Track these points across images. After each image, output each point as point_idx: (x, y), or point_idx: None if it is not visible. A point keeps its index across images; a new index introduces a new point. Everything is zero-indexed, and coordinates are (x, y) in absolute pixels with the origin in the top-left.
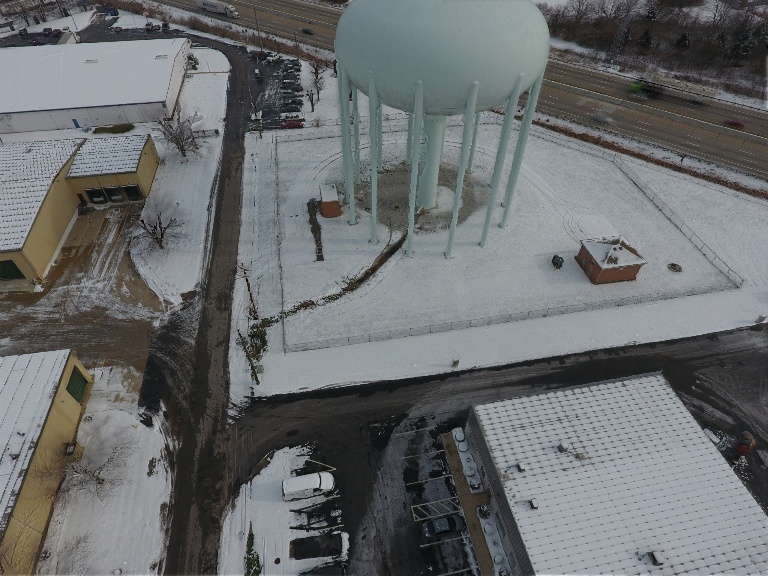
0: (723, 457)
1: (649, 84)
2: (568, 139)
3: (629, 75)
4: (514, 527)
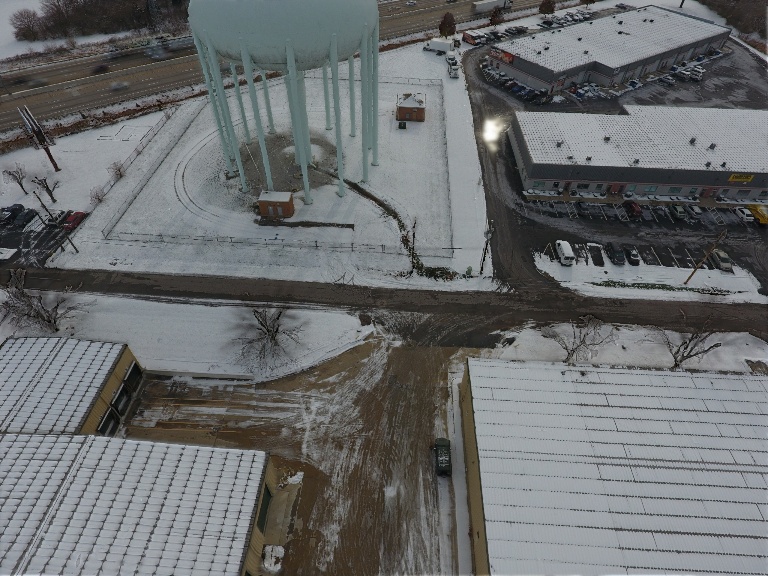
0: None
1: None
2: (261, 83)
3: None
4: (598, 168)
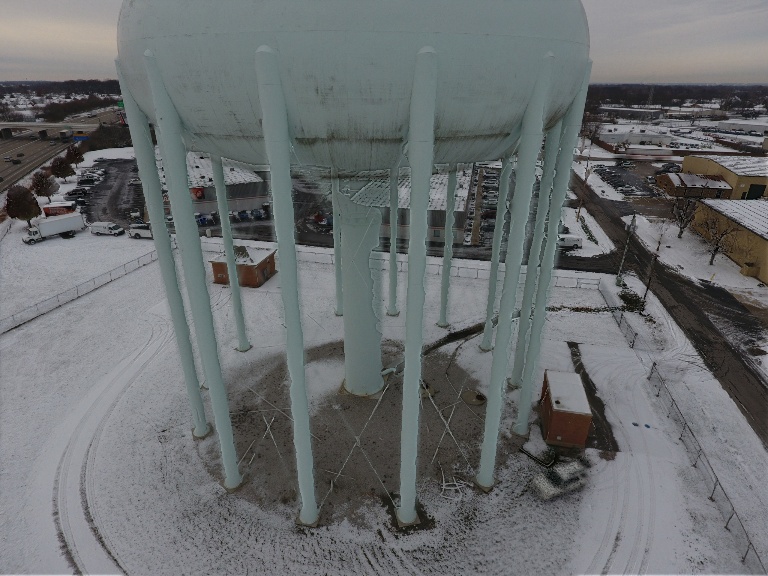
0: None
1: None
2: None
3: None
4: None
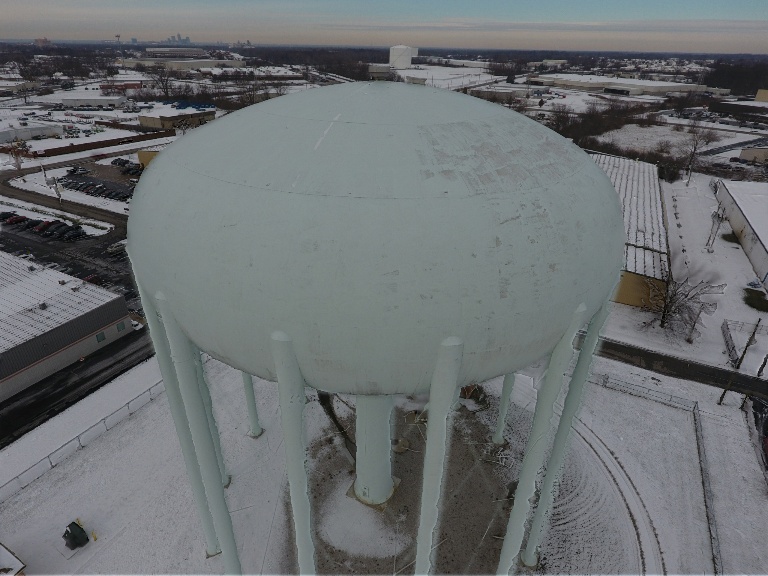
0: None
1: None
2: None
3: None
4: None
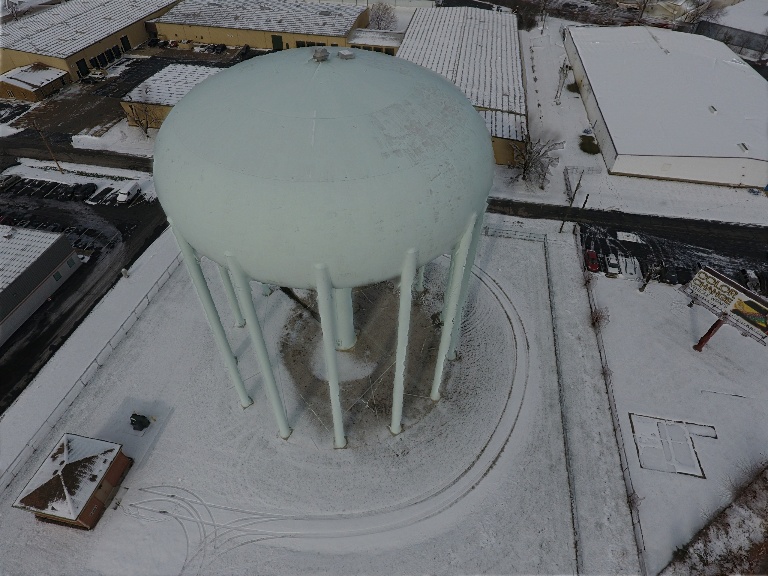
0: None
1: None
2: None
3: None
4: None
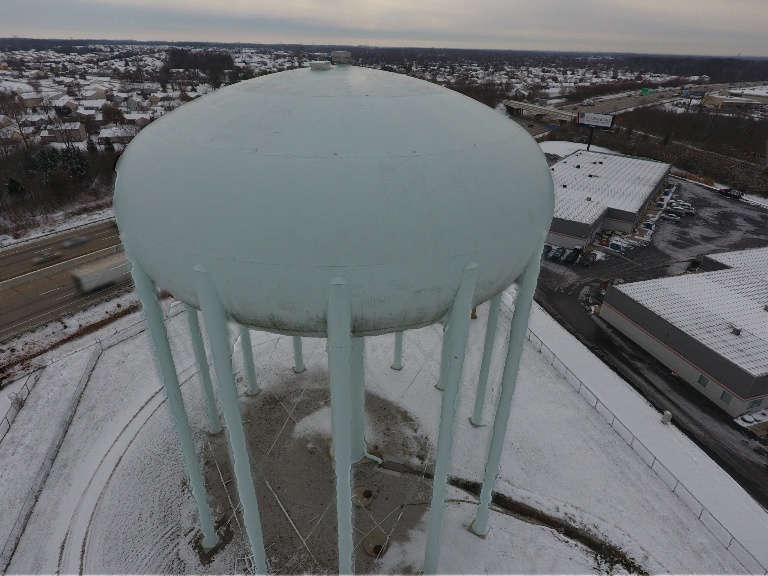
0: (660, 278)
1: (82, 227)
2: None
3: (35, 235)
4: None
